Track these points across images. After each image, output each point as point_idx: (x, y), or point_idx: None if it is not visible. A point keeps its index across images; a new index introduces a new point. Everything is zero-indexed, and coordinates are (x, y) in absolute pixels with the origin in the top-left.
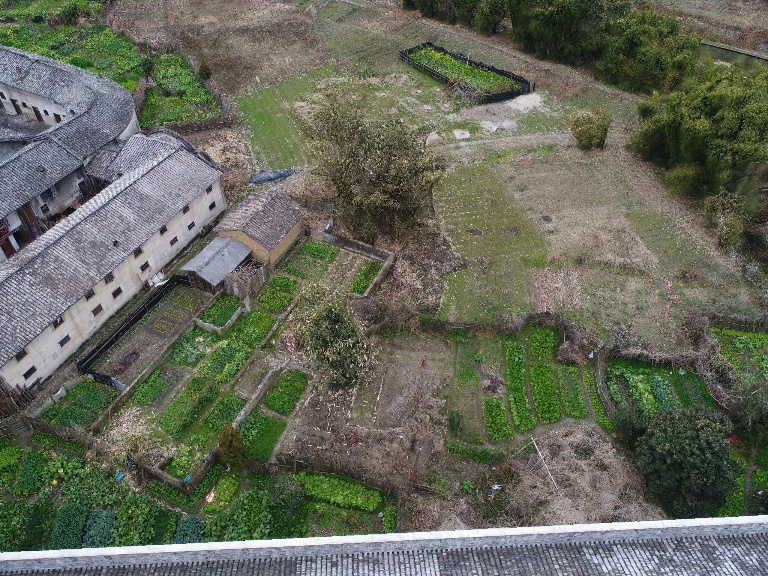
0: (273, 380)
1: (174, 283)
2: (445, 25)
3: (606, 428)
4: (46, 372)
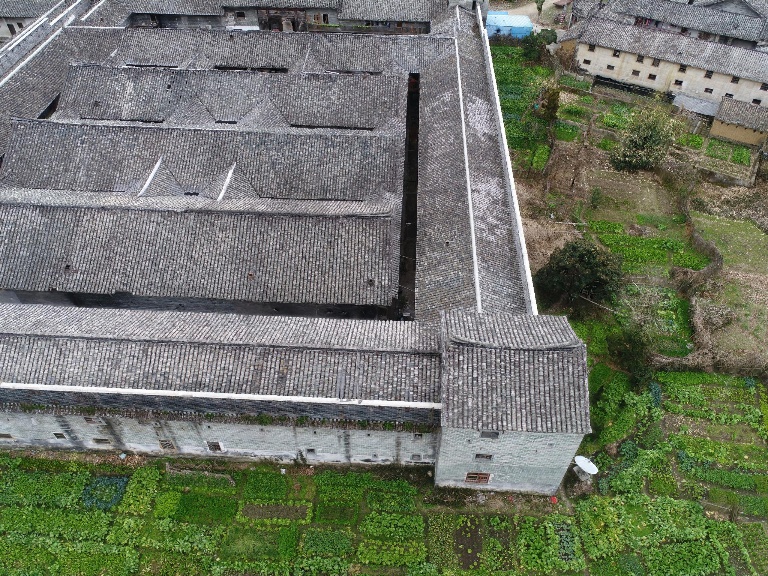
0: (610, 138)
1: None
2: None
3: None
4: (592, 71)
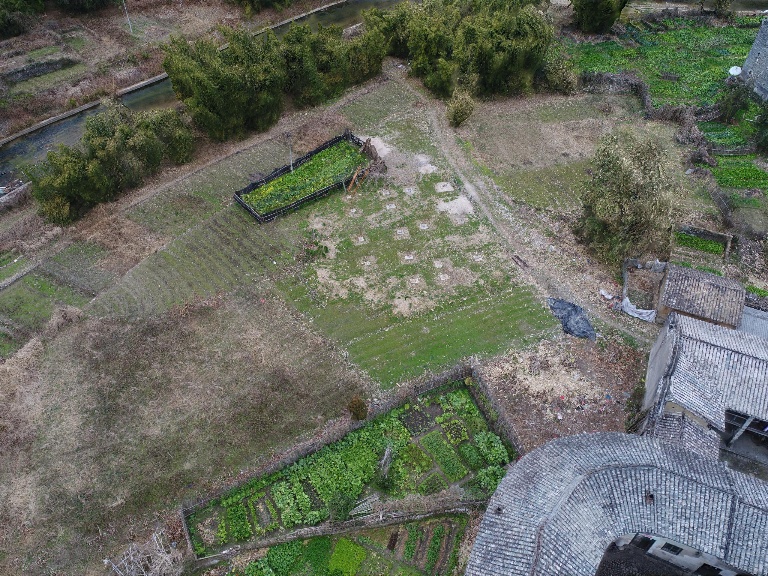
0: None
1: None
2: (148, 187)
3: (755, 157)
4: None
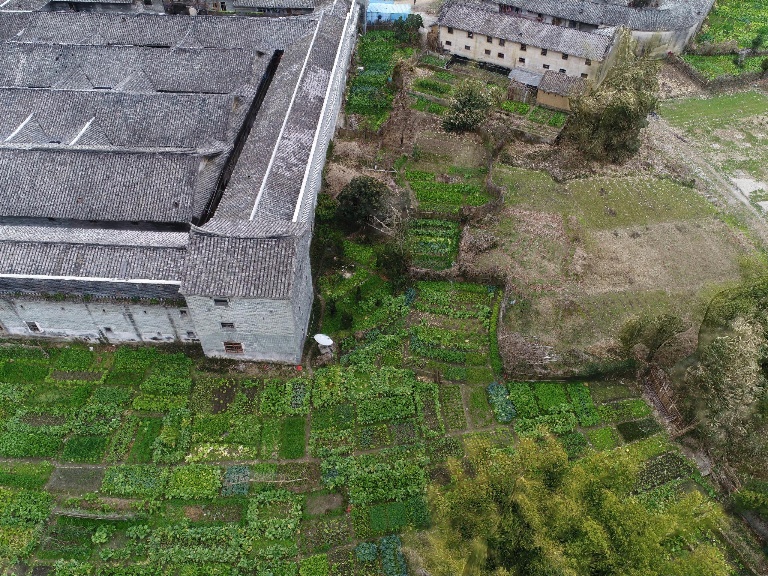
0: None
1: None
2: None
3: None
4: (454, 52)
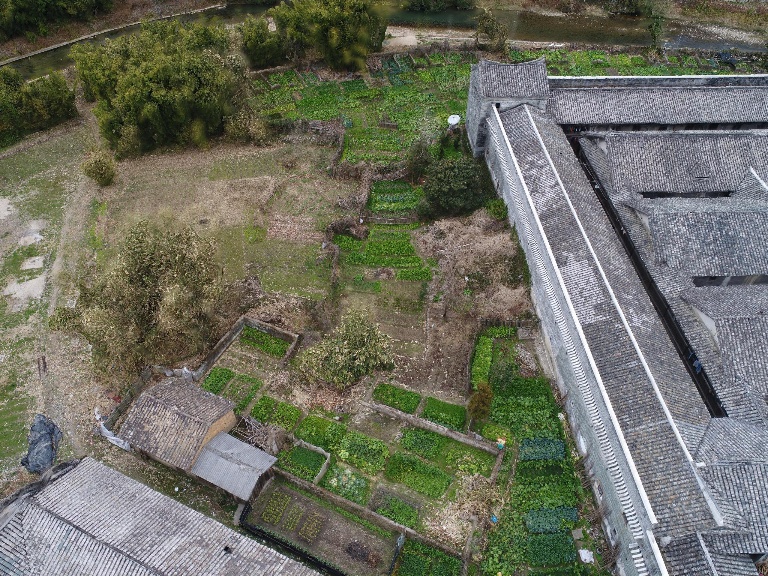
0: None
1: (238, 532)
2: None
3: (418, 226)
4: None
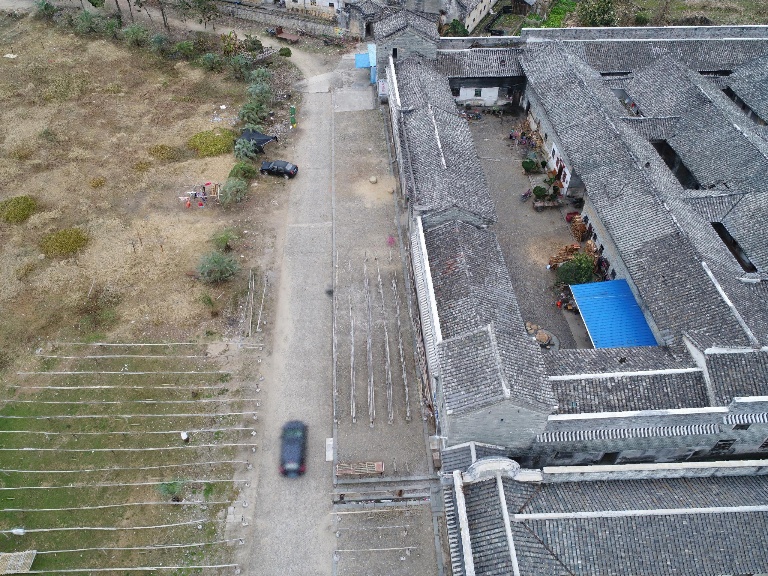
0: None
1: None
2: None
3: None
4: None
